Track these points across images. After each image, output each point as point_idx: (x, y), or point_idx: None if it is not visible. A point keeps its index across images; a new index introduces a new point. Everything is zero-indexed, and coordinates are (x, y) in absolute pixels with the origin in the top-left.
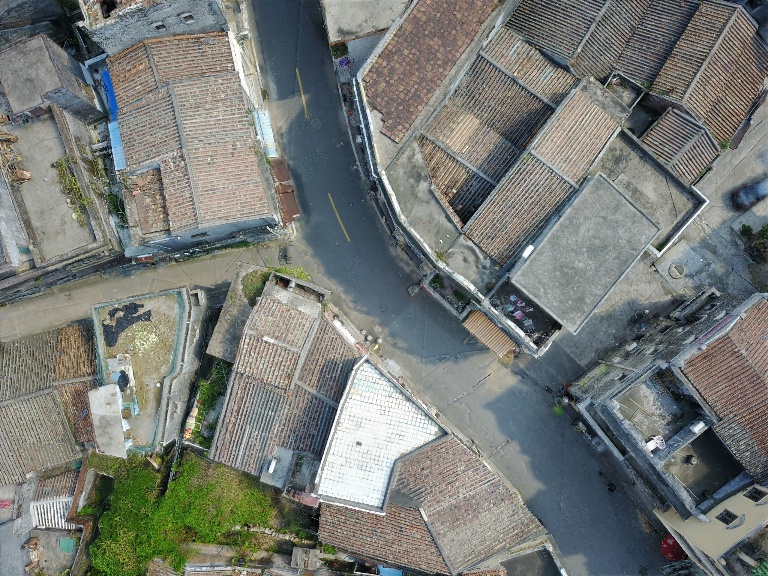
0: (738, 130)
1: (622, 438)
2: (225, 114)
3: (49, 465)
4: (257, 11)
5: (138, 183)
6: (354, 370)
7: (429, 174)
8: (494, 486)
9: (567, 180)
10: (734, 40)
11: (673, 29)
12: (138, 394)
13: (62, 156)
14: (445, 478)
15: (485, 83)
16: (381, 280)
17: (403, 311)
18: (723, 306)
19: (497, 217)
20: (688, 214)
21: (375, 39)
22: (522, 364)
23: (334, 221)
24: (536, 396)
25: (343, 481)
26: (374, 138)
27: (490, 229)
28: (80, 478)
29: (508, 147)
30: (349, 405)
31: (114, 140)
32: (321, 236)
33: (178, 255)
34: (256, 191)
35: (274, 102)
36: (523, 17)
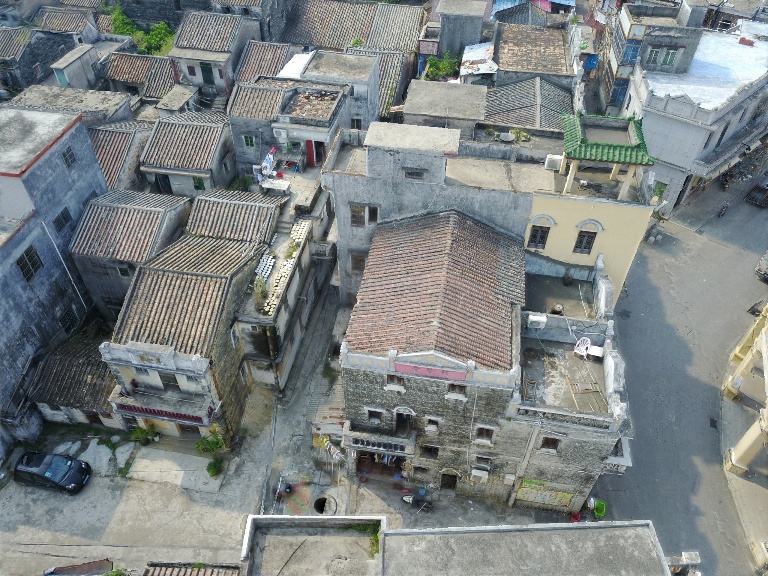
0: None
1: None
2: None
3: None
4: None
5: None
6: None
7: None
8: None
9: None
10: None
11: None
12: None
13: None
14: None
15: None
16: None
17: None
18: (373, 399)
19: None
20: (285, 531)
21: None
22: None
23: None
24: None
25: None
26: None
27: None
28: None
29: None
30: None
31: None
32: None
33: None
34: None
35: None
36: None
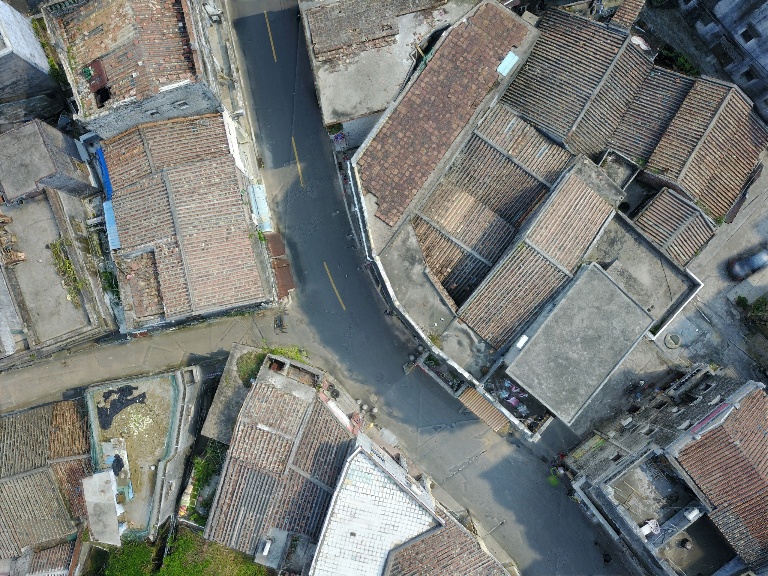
0: (733, 205)
1: (617, 521)
2: (219, 198)
3: (44, 540)
4: (252, 79)
5: (132, 267)
6: (348, 462)
7: (424, 257)
8: (489, 569)
9: (561, 269)
10: (729, 119)
11: (668, 105)
12: (133, 477)
13: (56, 238)
14: (440, 562)
15: (480, 161)
16: (376, 349)
17: (398, 380)
18: (718, 389)
19: (491, 302)
20: (683, 296)
21: (370, 117)
22: (518, 433)
23: (329, 290)
24: (532, 465)
25: (337, 572)
26: (368, 224)
27: (484, 314)
28: (75, 551)
29: (503, 225)
30: (343, 495)
31: (109, 219)
32: (316, 305)
33: (173, 328)
34: (250, 275)
35: (269, 170)
36: (518, 92)
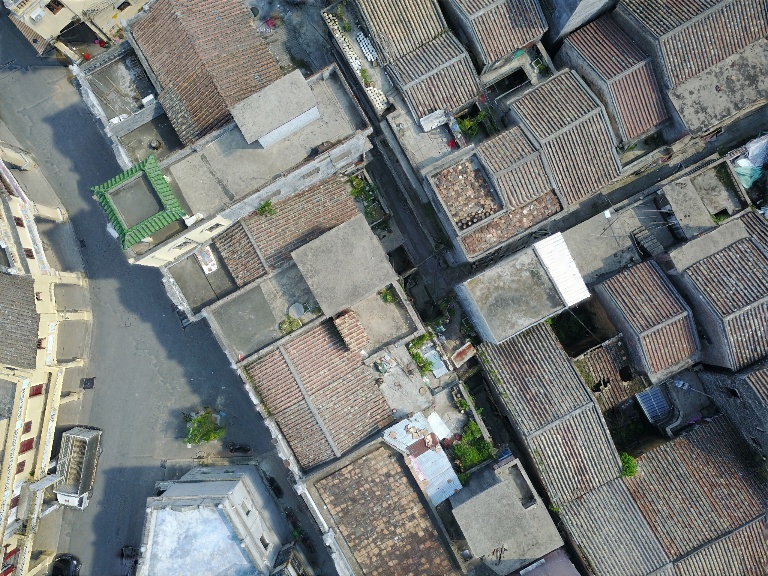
0: None
1: (94, 115)
2: None
3: None
4: None
5: None
6: None
7: None
8: None
9: None
10: None
11: None
12: None
13: None
14: None
15: None
16: None
17: None
18: None
19: None
20: None
21: None
22: None
23: None
24: None
25: None
26: None
27: None
28: None
29: None
30: None
31: None
32: None
33: None
34: None
35: None
36: None
